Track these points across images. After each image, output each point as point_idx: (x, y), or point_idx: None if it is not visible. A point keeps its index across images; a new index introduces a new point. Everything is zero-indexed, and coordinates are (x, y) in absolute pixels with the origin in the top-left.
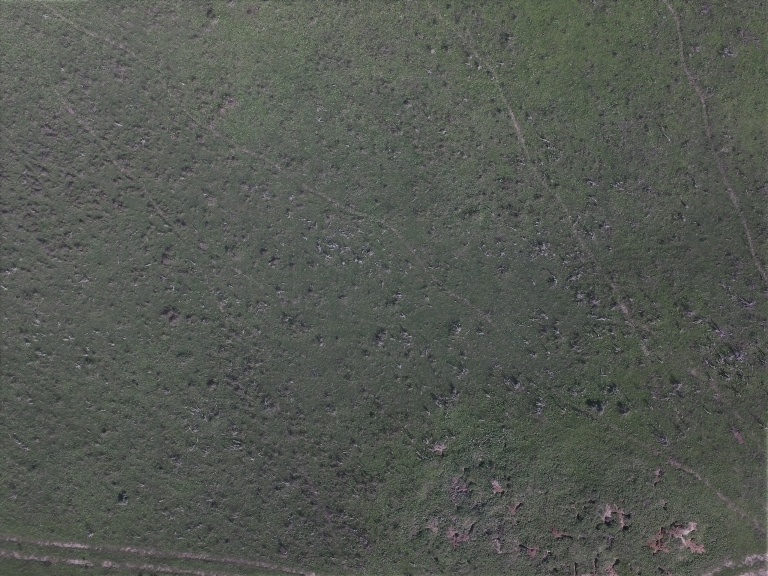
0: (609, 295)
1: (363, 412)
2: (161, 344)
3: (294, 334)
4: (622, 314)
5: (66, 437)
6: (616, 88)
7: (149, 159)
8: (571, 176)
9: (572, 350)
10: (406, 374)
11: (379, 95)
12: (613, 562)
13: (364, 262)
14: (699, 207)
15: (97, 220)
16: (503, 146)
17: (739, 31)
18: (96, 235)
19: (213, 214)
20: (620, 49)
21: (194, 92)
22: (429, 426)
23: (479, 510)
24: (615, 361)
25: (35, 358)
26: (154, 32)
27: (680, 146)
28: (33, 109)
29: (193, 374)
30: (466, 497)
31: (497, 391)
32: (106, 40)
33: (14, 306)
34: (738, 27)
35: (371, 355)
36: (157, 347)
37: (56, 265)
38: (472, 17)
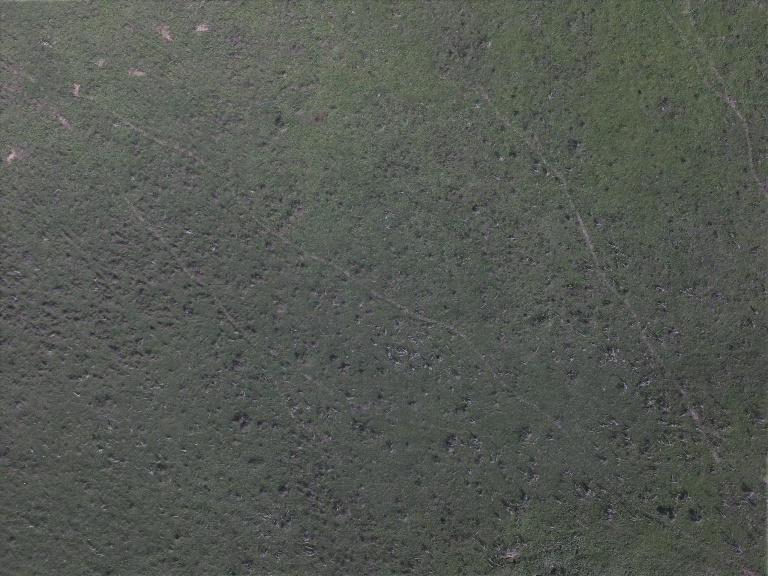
0: (679, 401)
1: (434, 518)
2: (232, 450)
3: (365, 440)
4: (693, 421)
5: (139, 543)
6: (685, 195)
7: (219, 266)
8: (640, 282)
9: (643, 456)
10: (476, 480)
11: (447, 202)
12: None
13: (433, 368)
14: None
15: (168, 327)
16: (572, 252)
17: None
18: (167, 342)
19: (283, 320)
20: (689, 155)
21: (263, 199)
22: (500, 532)
23: None
24: (686, 468)
25: (108, 464)
26: (223, 140)
27: (749, 252)
28: (103, 217)
29: (264, 480)
30: None
31: (568, 497)
32: (175, 148)
33: (87, 412)
34: None
35: (441, 461)
36: (228, 453)
37: (128, 372)
38: (540, 124)
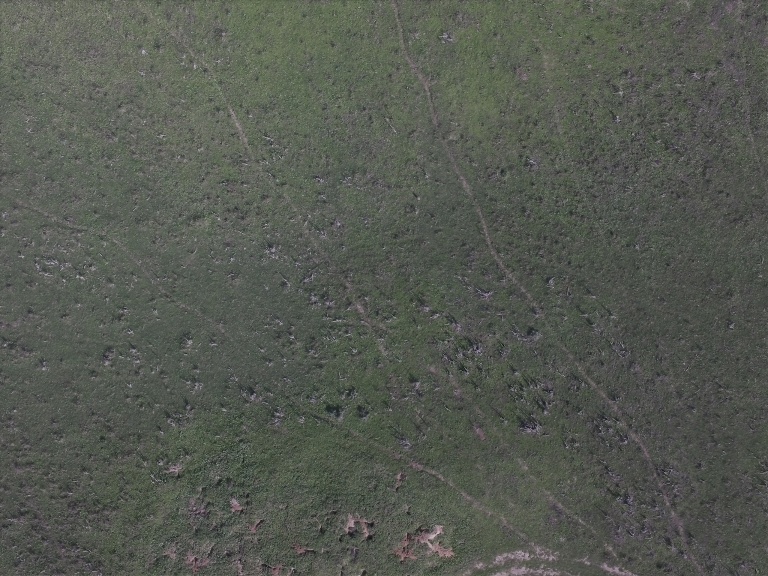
0: (344, 295)
1: (93, 437)
2: None
3: (14, 359)
4: (358, 314)
5: None
6: (337, 80)
7: None
8: (298, 174)
9: (309, 355)
10: (137, 393)
11: (92, 101)
12: (359, 574)
13: (86, 278)
14: (432, 198)
15: None
16: (225, 147)
17: (457, 15)
18: None
19: None
20: (339, 40)
21: None
22: (163, 446)
23: (218, 531)
24: (353, 363)
25: None
26: None
27: (407, 136)
28: None
29: None
30: (204, 518)
31: (234, 404)
32: None
33: None
34: (456, 11)
35: (99, 376)
36: None
37: None
38: (184, 14)
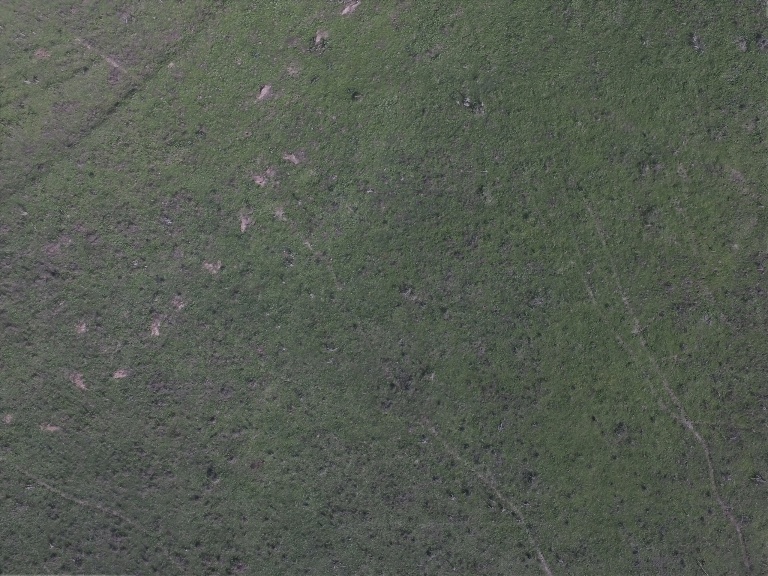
0: None
1: None
2: None
3: None
4: None
5: None
6: (648, 523)
7: None
8: None
9: None
10: None
11: (399, 545)
12: None
13: None
14: None
15: None
16: None
17: None
18: None
19: None
20: (649, 481)
21: (199, 557)
22: None
23: None
24: None
25: None
26: (150, 495)
27: None
28: None
29: None
30: None
31: None
32: (98, 507)
33: None
34: None
35: None
36: None
37: None
38: (492, 457)
